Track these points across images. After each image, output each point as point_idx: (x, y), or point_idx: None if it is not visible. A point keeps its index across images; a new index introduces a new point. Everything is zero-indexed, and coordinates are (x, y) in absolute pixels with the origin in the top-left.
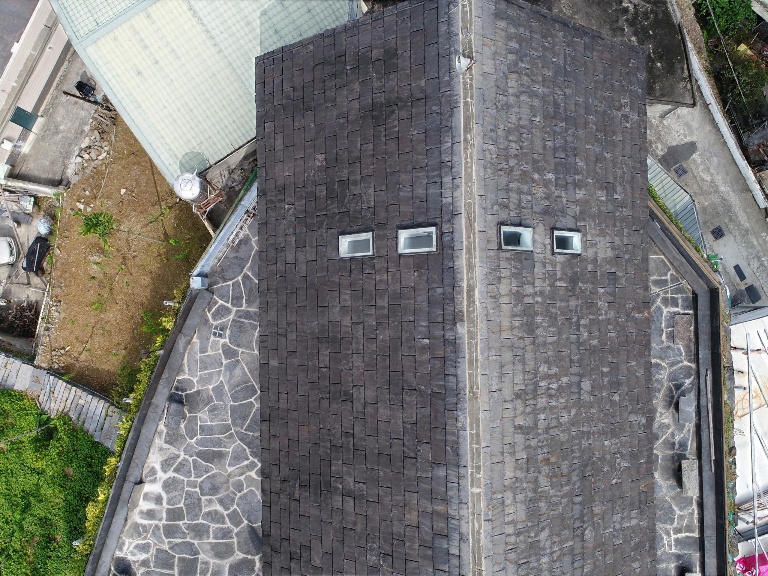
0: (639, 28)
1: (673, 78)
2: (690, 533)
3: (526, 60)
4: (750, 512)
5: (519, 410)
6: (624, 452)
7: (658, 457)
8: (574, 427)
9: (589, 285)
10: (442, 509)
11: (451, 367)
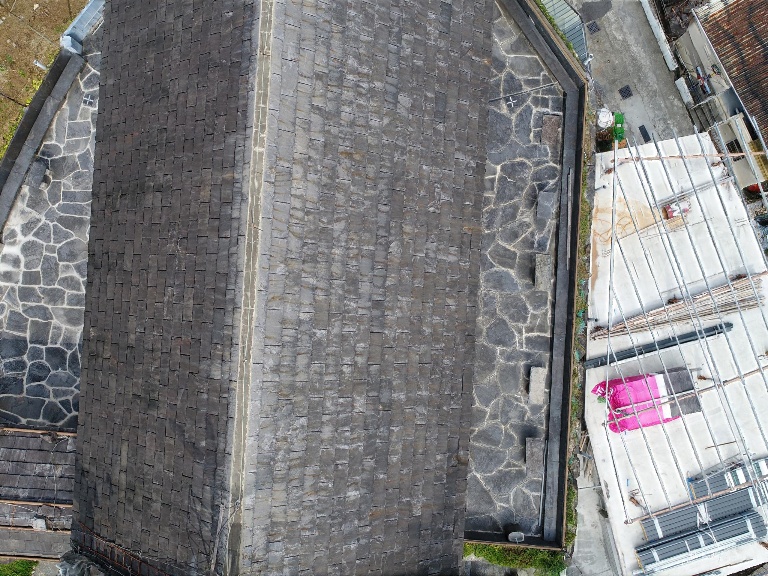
0: None
1: None
2: (542, 333)
3: None
4: (615, 335)
5: (319, 91)
6: (446, 185)
7: (516, 255)
8: (386, 136)
9: (417, 4)
10: (230, 176)
11: (247, 31)
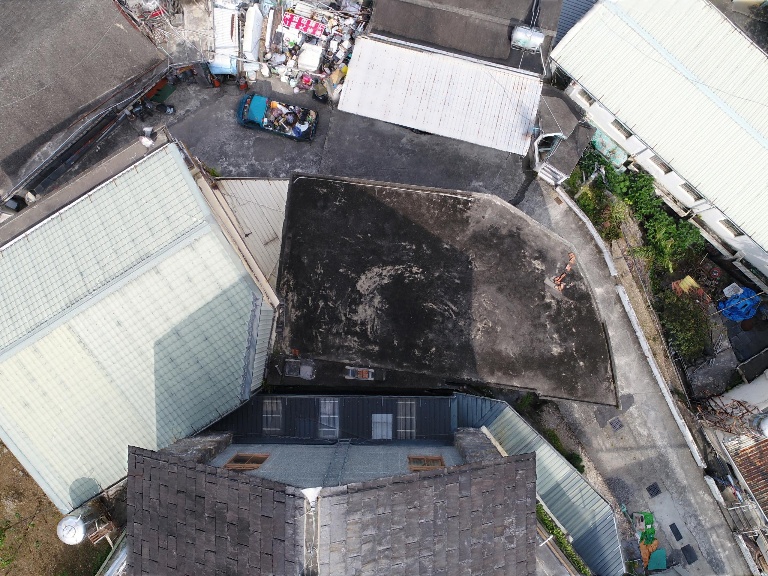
0: (562, 325)
1: (596, 378)
2: None
3: (385, 540)
4: None
5: None
6: None
7: None
8: None
9: None
10: None
11: None
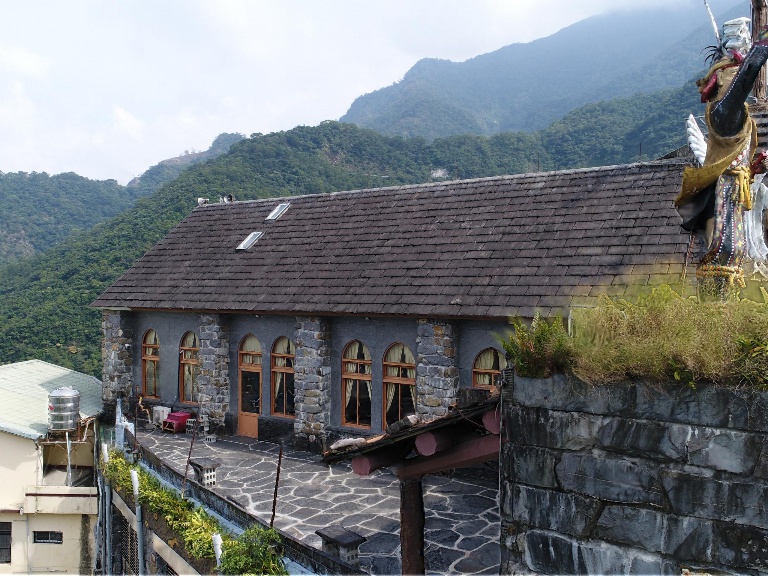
0: None
1: None
2: None
3: None
4: None
5: None
6: None
7: None
8: None
9: None
10: None
11: None
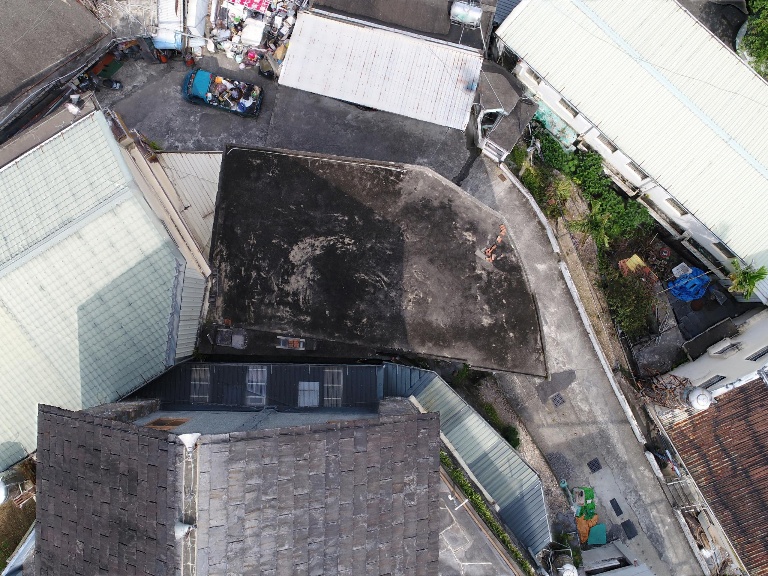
0: (492, 296)
1: (526, 349)
2: None
3: (272, 490)
4: None
5: None
6: None
7: None
8: None
9: None
10: None
11: None
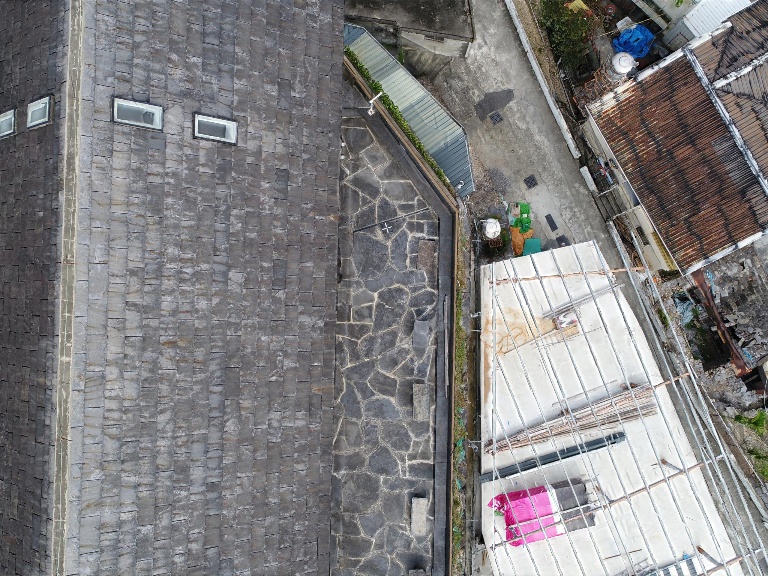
0: None
1: (454, 11)
2: (425, 460)
3: None
4: (508, 448)
5: (134, 287)
6: (290, 351)
7: (396, 382)
8: (216, 316)
9: (248, 177)
10: (43, 381)
11: (53, 237)
